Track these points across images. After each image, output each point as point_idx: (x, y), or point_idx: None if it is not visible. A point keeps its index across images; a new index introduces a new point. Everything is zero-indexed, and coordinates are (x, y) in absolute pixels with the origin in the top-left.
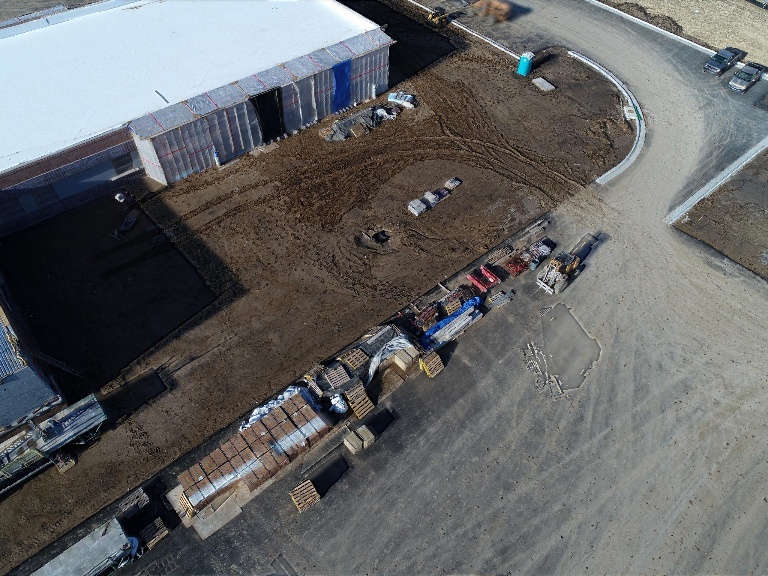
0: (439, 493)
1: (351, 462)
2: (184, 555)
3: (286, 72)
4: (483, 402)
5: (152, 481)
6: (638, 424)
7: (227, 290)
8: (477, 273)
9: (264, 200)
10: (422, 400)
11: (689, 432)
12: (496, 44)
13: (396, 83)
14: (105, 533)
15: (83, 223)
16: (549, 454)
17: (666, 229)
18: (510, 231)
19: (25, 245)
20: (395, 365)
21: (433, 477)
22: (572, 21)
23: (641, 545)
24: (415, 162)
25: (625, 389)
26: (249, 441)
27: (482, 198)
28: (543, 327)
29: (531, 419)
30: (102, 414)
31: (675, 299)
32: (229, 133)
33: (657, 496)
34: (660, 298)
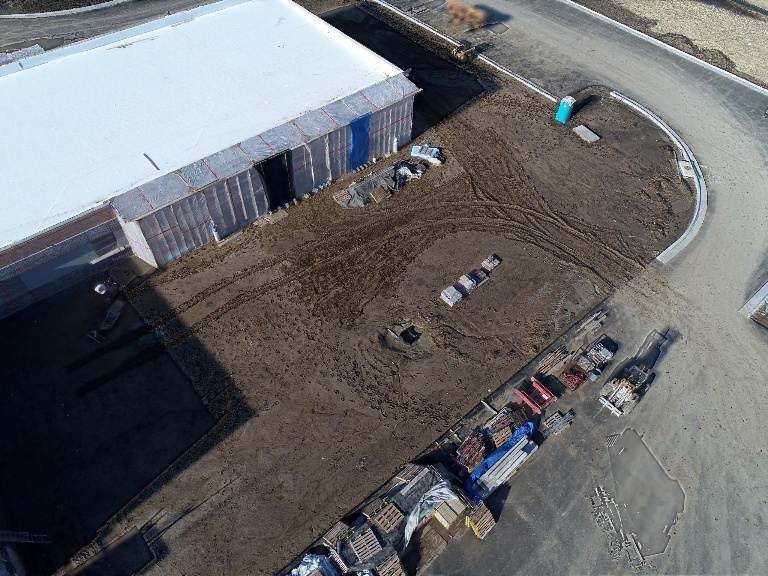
0: None
1: None
2: None
3: (296, 131)
4: (547, 575)
5: None
6: None
7: (228, 411)
8: (527, 386)
9: (271, 286)
10: (471, 573)
11: None
12: (529, 83)
13: (419, 133)
14: None
15: (57, 319)
16: None
17: (745, 324)
18: (562, 327)
19: None
20: (435, 520)
21: None
22: (611, 55)
23: None
24: (446, 234)
25: (720, 555)
26: None
27: (526, 282)
28: (612, 463)
29: None
30: None
31: (767, 422)
32: (230, 204)
33: None
34: (748, 420)
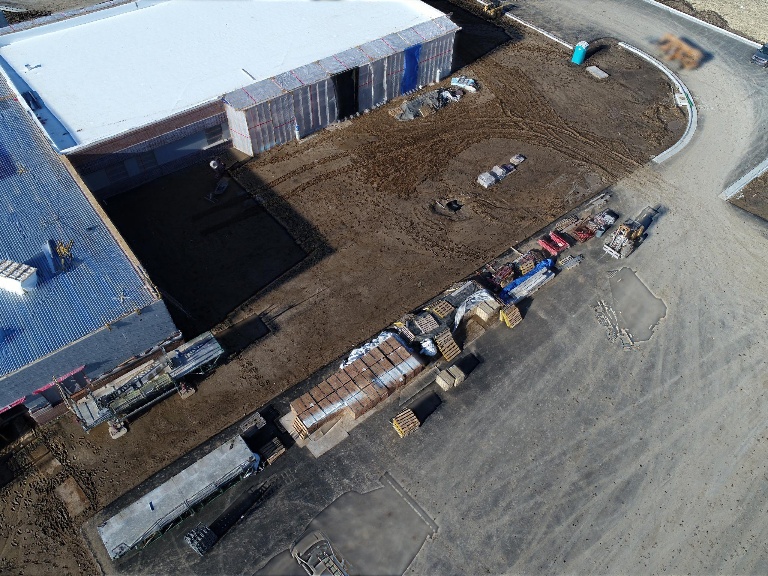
0: (526, 426)
1: (443, 397)
2: (301, 470)
3: (362, 54)
4: (560, 350)
5: (266, 408)
6: (705, 373)
7: (316, 248)
8: (546, 239)
9: (343, 171)
10: (504, 347)
11: (754, 381)
12: (549, 35)
13: (457, 69)
14: (232, 447)
15: (179, 187)
16: (624, 396)
17: (722, 204)
18: (574, 203)
19: (129, 205)
20: (477, 316)
21: (519, 412)
22: (621, 15)
23: (714, 475)
24: (480, 140)
25: (692, 342)
26: (352, 375)
27: (546, 173)
28: (611, 287)
29: (606, 366)
30: (219, 348)
31: (734, 266)
32: (310, 109)
33: (727, 434)
34: (720, 265)
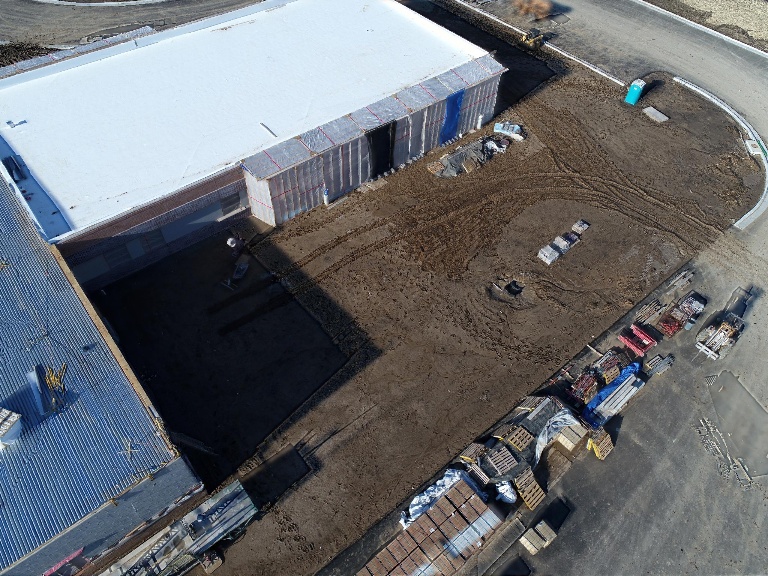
0: None
1: (531, 564)
2: None
3: (399, 104)
4: (665, 491)
5: None
6: None
7: (358, 350)
8: (627, 333)
9: (381, 244)
10: (596, 487)
11: None
12: (596, 69)
13: (499, 112)
14: None
15: (191, 269)
16: (753, 558)
17: None
18: (653, 283)
19: (132, 295)
20: (558, 444)
21: None
22: (671, 44)
23: None
24: (535, 202)
25: None
26: (418, 540)
27: (615, 244)
28: (713, 399)
29: (723, 513)
30: (252, 506)
31: None
32: (340, 170)
33: None
34: None
